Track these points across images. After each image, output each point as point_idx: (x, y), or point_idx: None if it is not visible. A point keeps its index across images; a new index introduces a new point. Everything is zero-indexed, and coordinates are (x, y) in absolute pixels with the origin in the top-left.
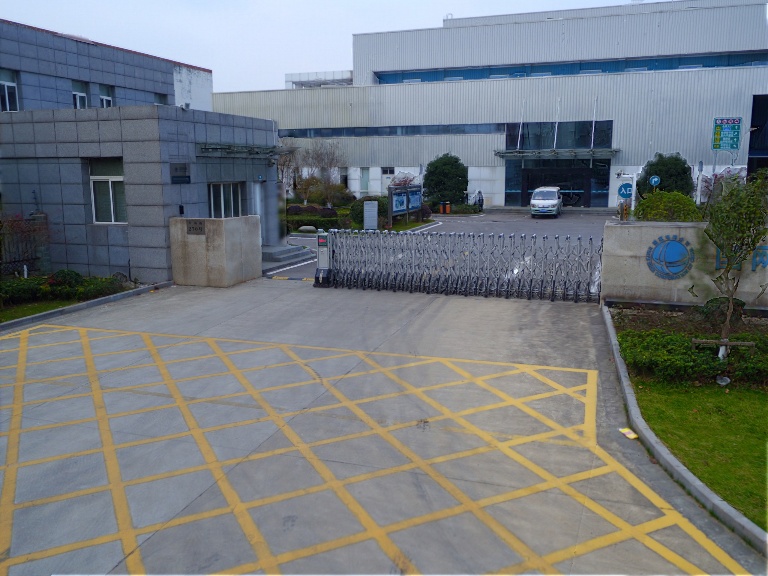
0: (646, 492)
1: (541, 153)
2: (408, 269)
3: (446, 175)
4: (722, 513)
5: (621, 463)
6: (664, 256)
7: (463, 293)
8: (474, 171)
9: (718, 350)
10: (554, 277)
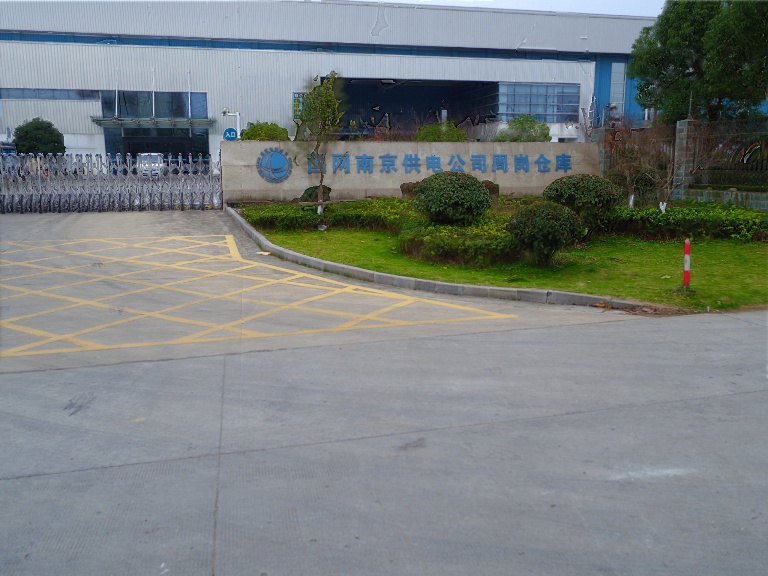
0: (282, 269)
1: (140, 122)
2: (34, 191)
3: (39, 140)
4: (331, 266)
5: (262, 263)
6: (270, 164)
7: (96, 211)
8: (70, 139)
9: (317, 209)
10: (181, 190)
